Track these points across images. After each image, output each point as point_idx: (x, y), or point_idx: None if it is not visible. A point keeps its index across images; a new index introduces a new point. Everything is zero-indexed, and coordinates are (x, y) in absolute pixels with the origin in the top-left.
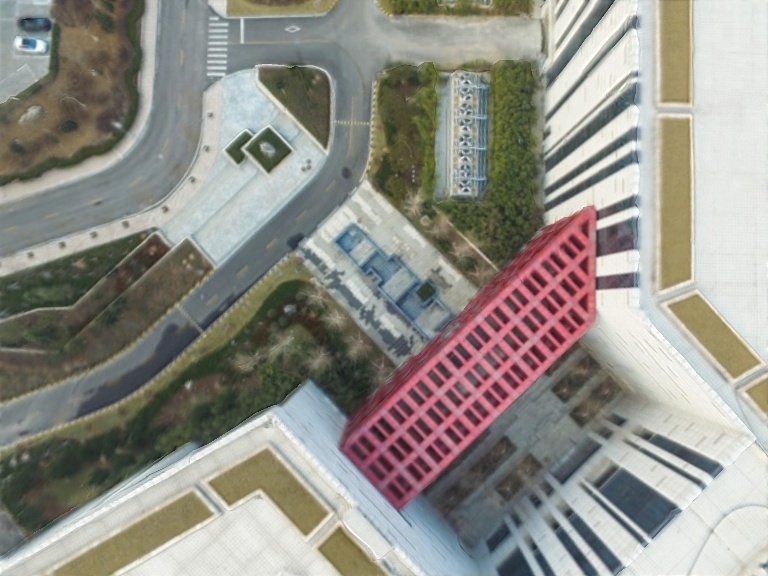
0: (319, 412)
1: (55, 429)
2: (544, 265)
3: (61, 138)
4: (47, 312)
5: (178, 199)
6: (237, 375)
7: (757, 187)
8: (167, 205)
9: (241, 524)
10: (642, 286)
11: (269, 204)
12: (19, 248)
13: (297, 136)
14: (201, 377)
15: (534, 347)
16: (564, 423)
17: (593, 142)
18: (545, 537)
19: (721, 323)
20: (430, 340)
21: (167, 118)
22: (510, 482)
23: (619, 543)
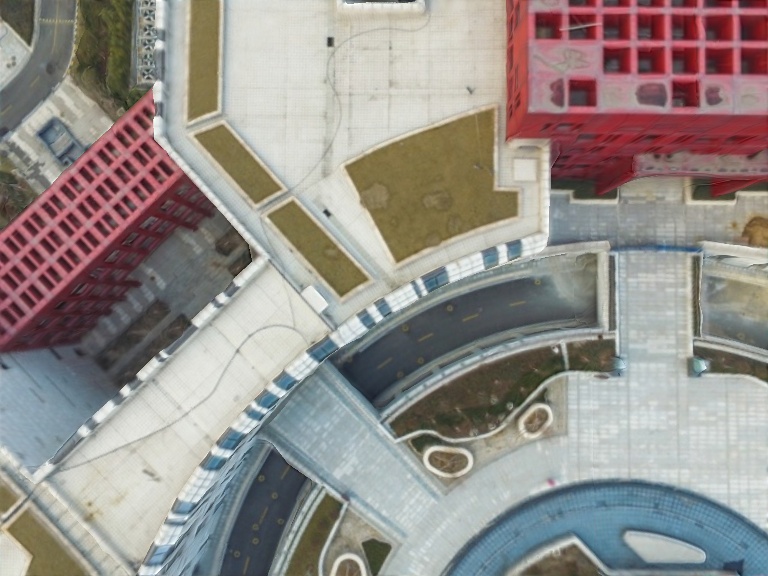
0: None
1: None
2: (137, 119)
3: None
4: None
5: None
6: None
7: (289, 24)
8: None
9: None
10: (175, 119)
11: None
12: None
13: (5, 35)
14: None
15: (126, 197)
16: None
17: None
18: None
19: (244, 151)
20: None
21: None
22: None
23: None
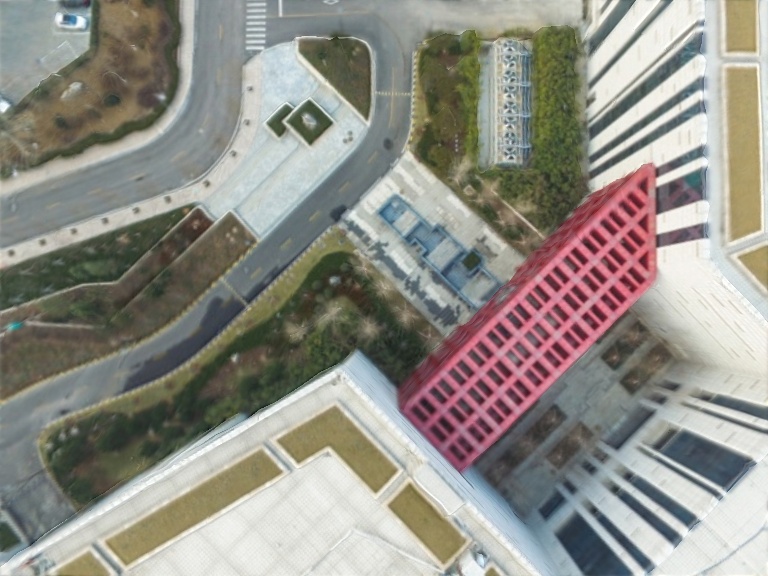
0: (374, 377)
1: (102, 403)
2: (603, 224)
3: (104, 113)
4: (92, 287)
5: (220, 173)
6: (285, 346)
7: None
8: (209, 179)
9: (310, 482)
10: (711, 238)
11: (311, 176)
12: (62, 225)
13: (338, 108)
14: (247, 350)
15: (594, 306)
16: (614, 390)
17: (650, 99)
18: (605, 499)
19: None
20: (477, 309)
21: (207, 93)
22: (561, 450)
23: (691, 498)
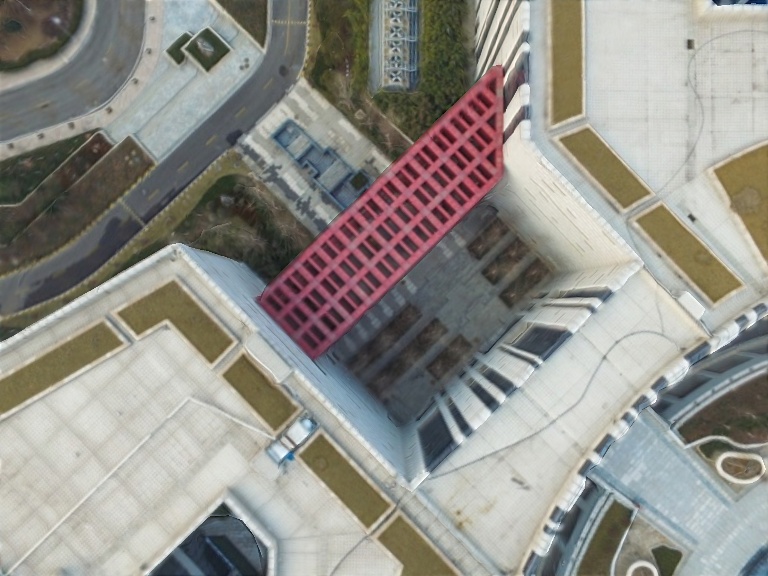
0: (243, 278)
1: (3, 320)
2: (453, 122)
3: (6, 39)
4: None
5: (121, 100)
6: None
7: (648, 26)
8: (111, 106)
9: (150, 354)
10: (535, 122)
11: (209, 102)
12: None
13: (236, 37)
14: None
15: (444, 201)
16: (493, 304)
17: (501, 4)
18: (460, 392)
19: (611, 155)
20: None
21: (111, 23)
22: (440, 361)
23: (514, 370)
